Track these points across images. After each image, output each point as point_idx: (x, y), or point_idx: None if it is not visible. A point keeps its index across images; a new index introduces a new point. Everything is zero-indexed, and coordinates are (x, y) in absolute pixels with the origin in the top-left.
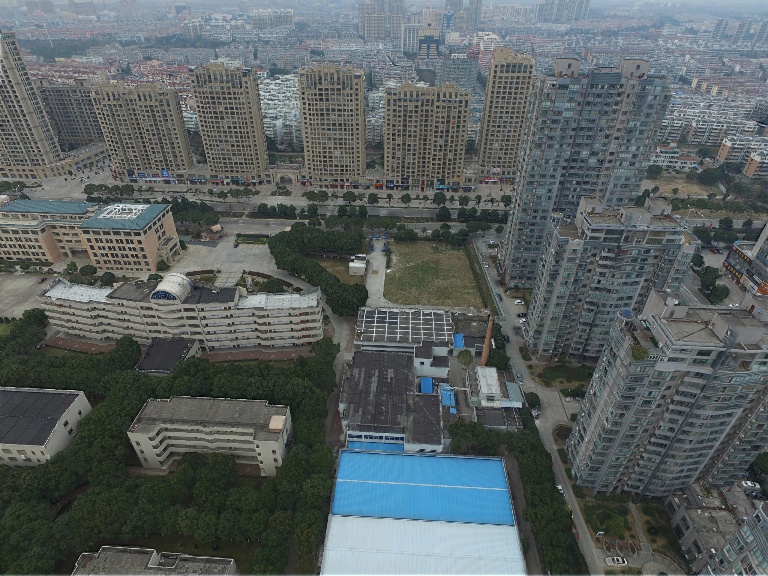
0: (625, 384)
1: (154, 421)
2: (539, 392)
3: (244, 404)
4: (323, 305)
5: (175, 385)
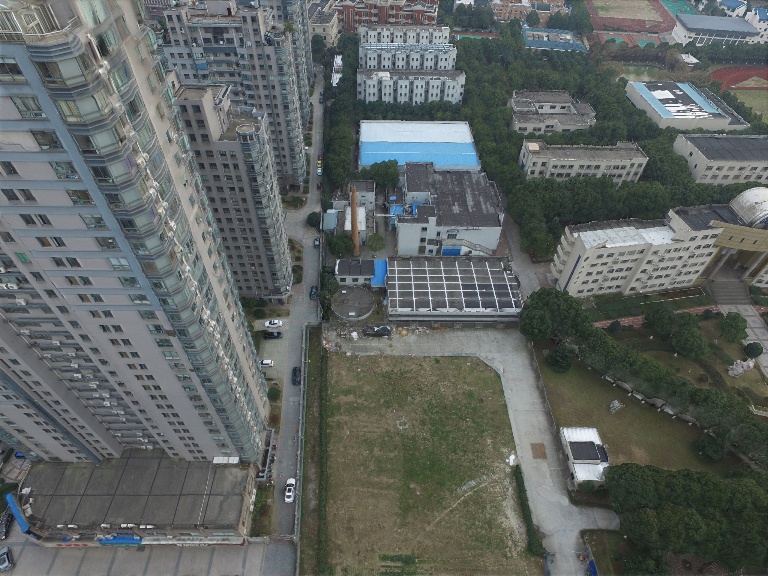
0: None
1: (626, 150)
2: (302, 234)
3: (569, 158)
4: None
5: None
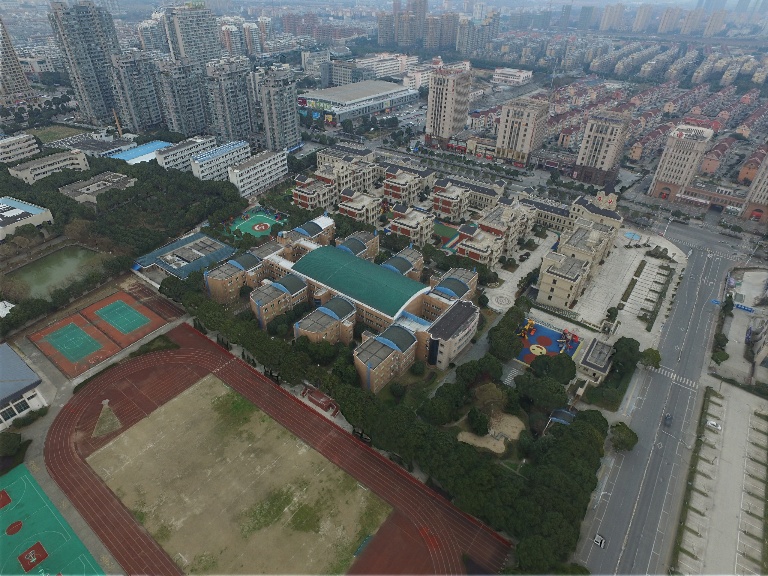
0: (170, 87)
1: (24, 169)
2: None
3: None
4: None
5: (7, 170)
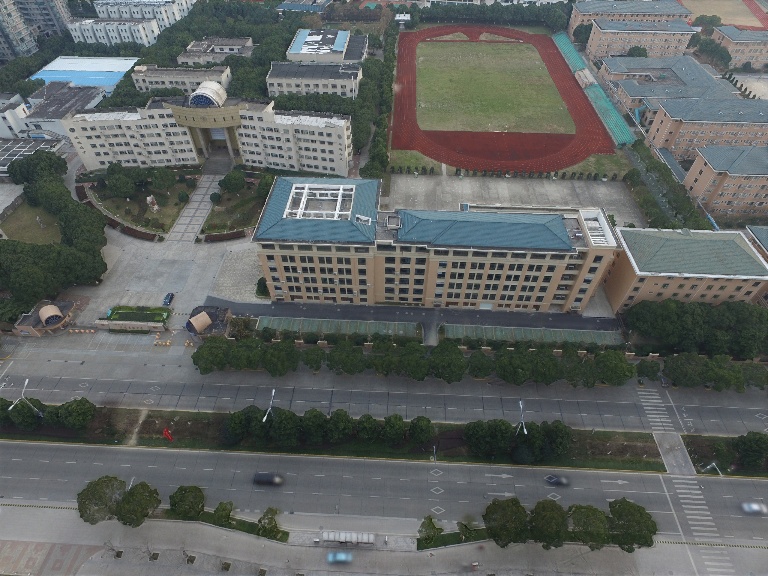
0: None
1: None
2: None
3: None
4: (74, 194)
5: None
